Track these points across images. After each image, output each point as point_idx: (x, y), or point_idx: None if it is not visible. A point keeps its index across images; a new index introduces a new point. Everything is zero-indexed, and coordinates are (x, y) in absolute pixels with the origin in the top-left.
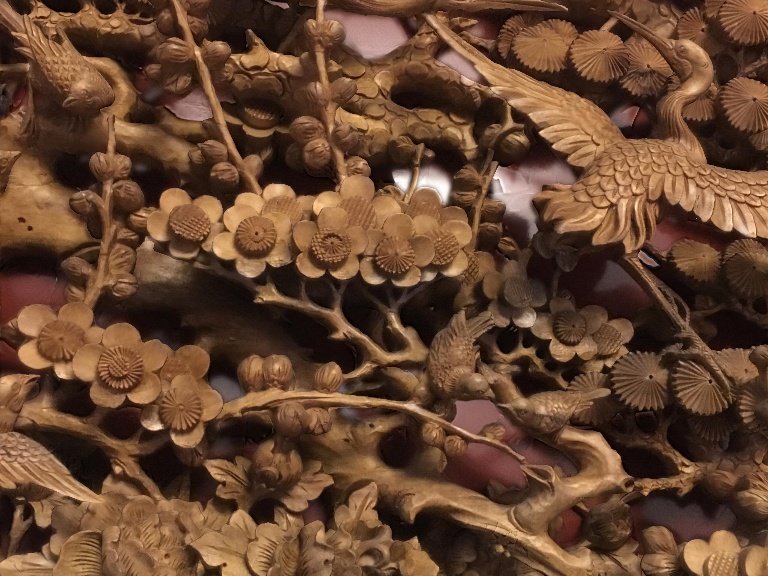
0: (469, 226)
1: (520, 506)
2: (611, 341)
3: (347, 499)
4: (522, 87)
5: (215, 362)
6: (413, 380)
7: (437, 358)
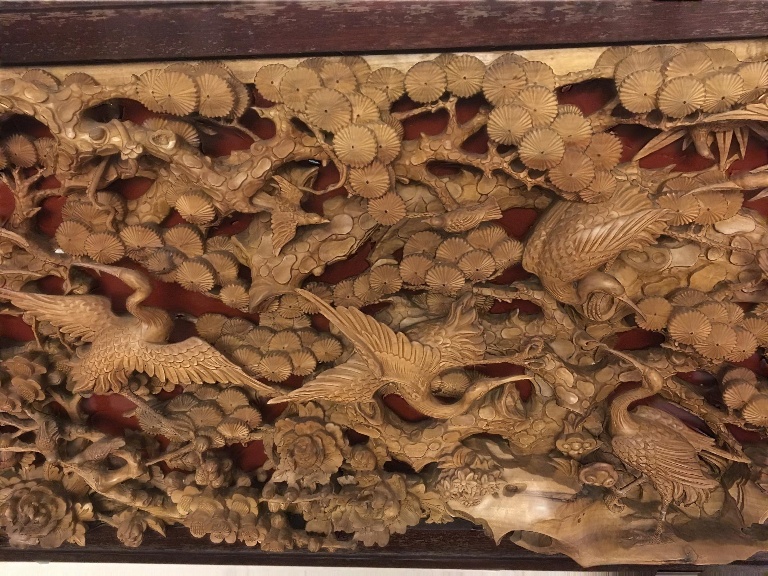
0: (37, 383)
1: None
2: None
3: None
4: (41, 309)
5: None
6: (66, 406)
7: None
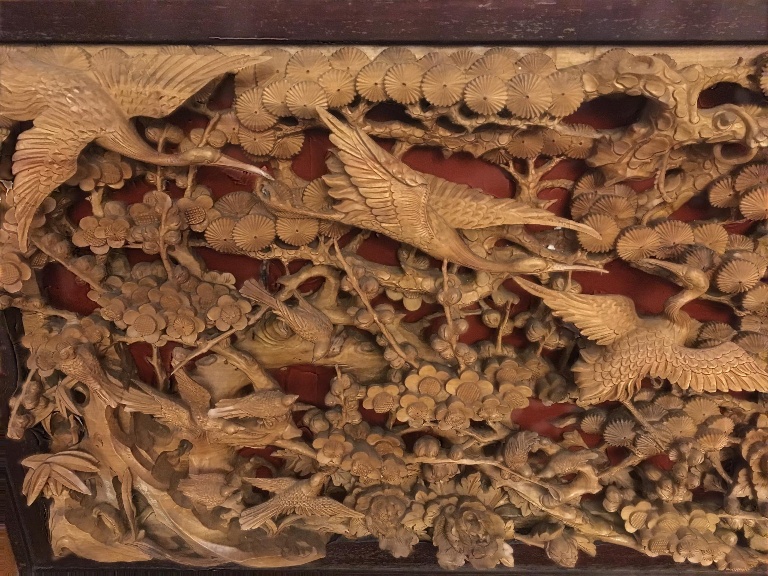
0: (531, 390)
1: (545, 499)
2: None
3: (467, 476)
4: (573, 309)
5: None
6: None
7: (508, 457)
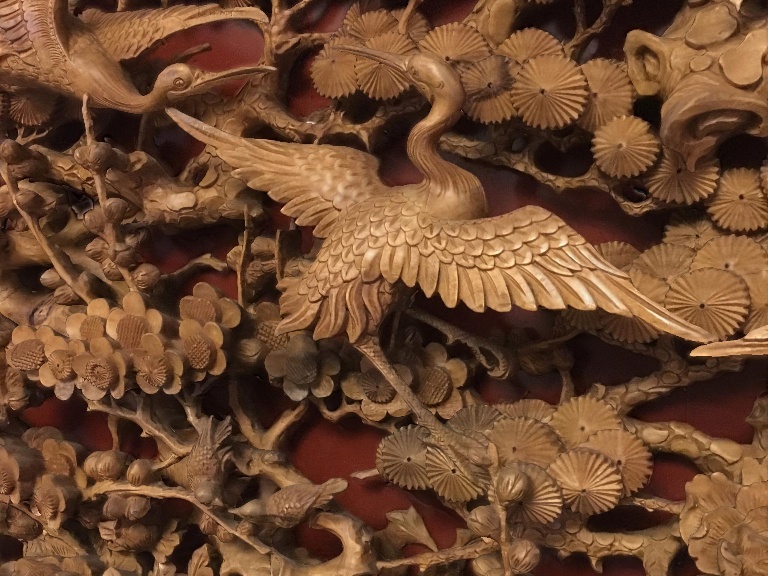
0: (219, 328)
1: None
2: (436, 390)
3: None
4: (260, 163)
5: (125, 429)
6: (256, 441)
7: (187, 465)
